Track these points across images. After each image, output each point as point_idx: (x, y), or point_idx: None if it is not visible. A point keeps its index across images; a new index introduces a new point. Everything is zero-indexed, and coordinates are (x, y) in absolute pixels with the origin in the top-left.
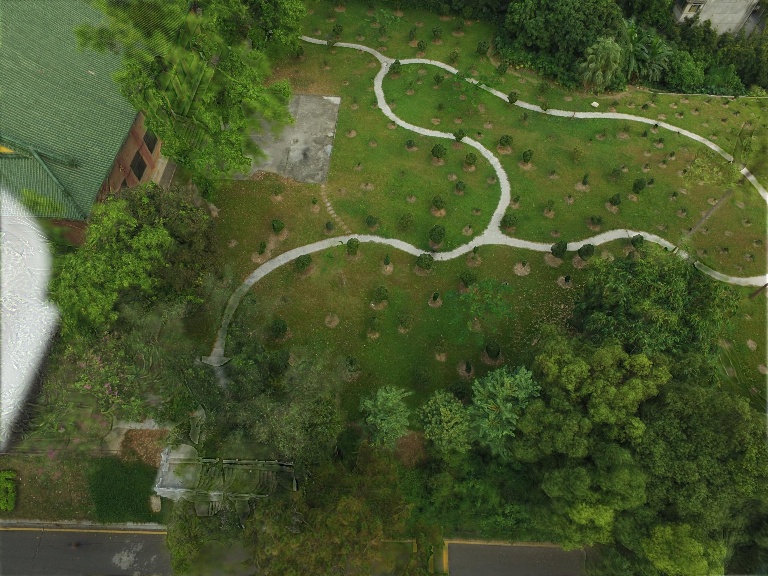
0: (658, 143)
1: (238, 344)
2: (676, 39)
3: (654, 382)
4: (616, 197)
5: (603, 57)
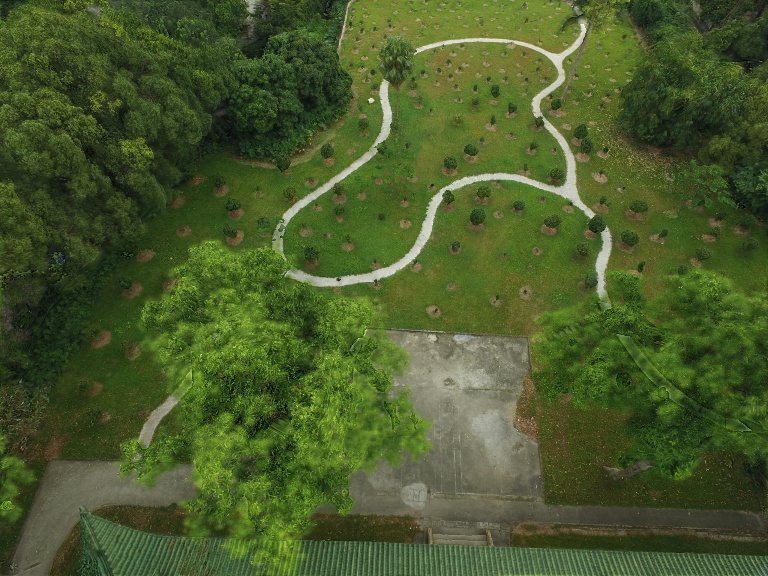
0: (423, 75)
1: None
2: (279, 30)
3: None
4: (513, 105)
5: None
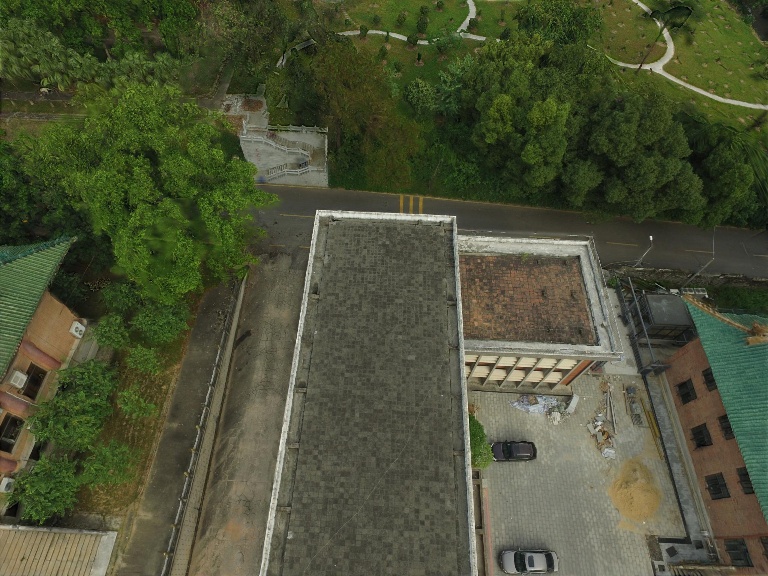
0: None
1: (303, 0)
2: None
3: (542, 47)
4: None
5: None
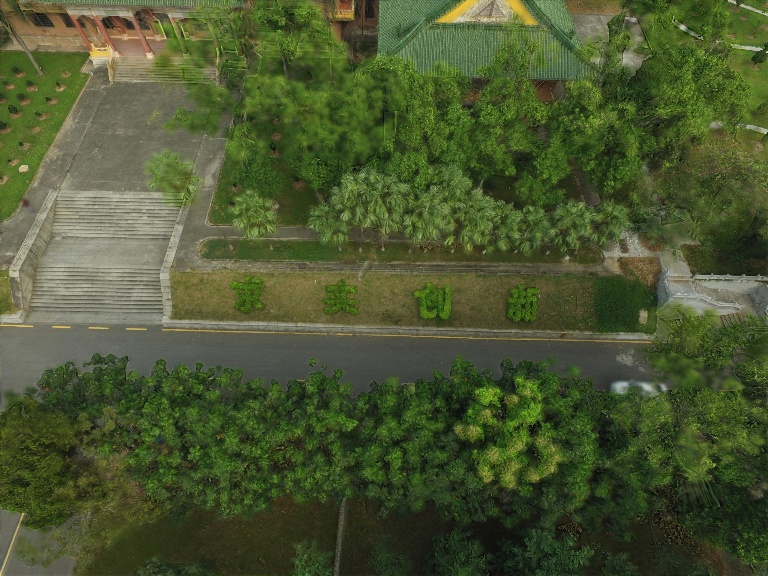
0: None
1: None
2: None
3: None
4: None
5: None
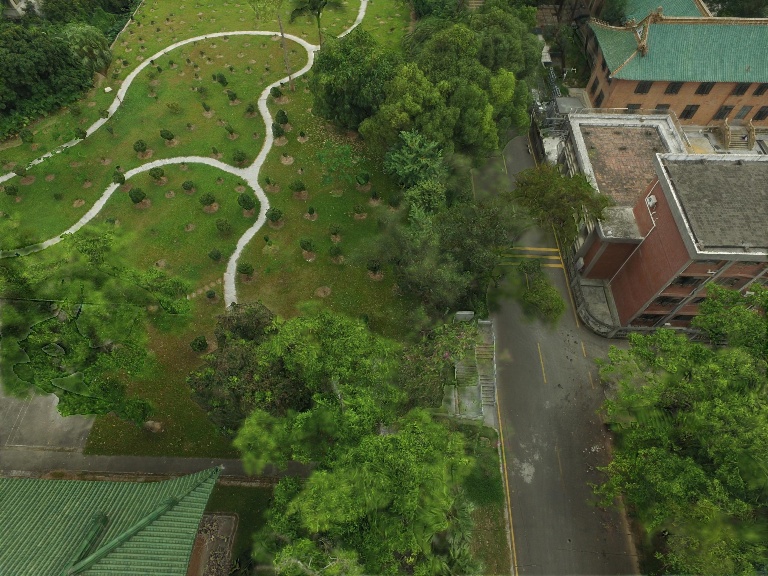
0: (172, 66)
1: None
2: (47, 24)
3: None
4: (231, 93)
5: (93, 40)
